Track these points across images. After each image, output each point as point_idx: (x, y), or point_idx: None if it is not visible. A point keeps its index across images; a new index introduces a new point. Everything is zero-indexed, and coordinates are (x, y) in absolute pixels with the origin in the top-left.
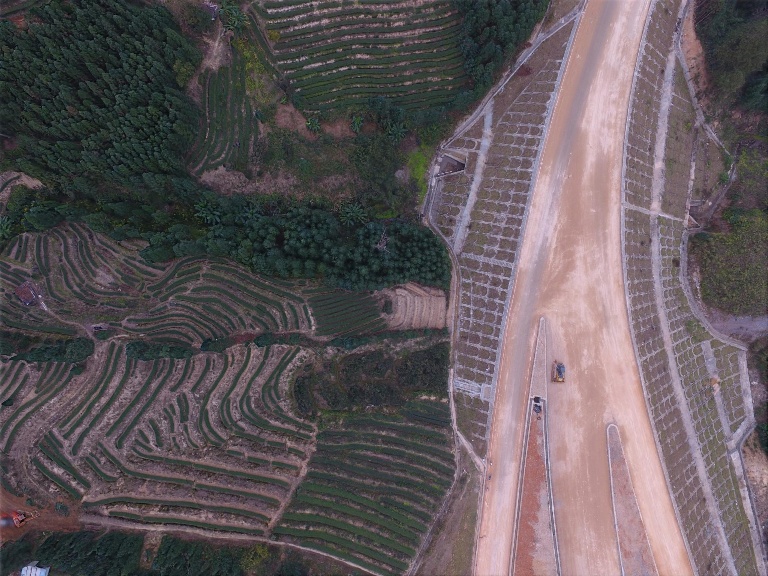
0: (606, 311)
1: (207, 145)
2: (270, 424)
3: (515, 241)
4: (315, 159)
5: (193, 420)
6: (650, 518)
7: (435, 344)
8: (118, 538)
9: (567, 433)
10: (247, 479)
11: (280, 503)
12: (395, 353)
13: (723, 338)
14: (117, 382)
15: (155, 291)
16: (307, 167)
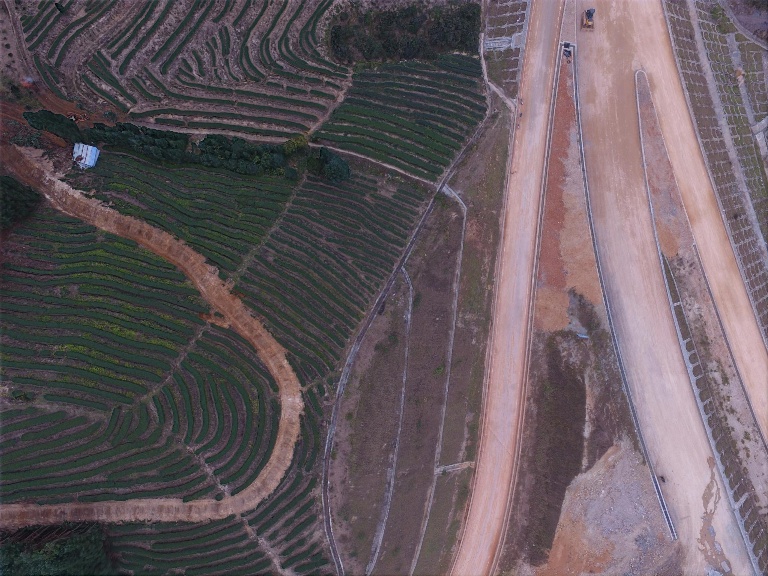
0: None
1: None
2: (307, 65)
3: None
4: None
5: (234, 54)
6: (678, 161)
7: (466, 6)
8: None
9: (596, 78)
10: (286, 103)
11: (318, 119)
12: (428, 12)
13: (747, 36)
14: (162, 7)
15: None
16: None
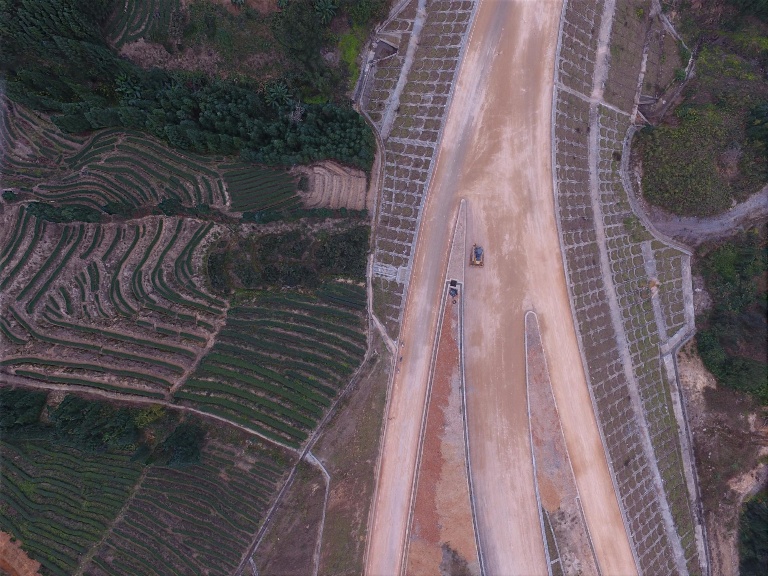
0: (531, 195)
1: (126, 15)
2: (182, 298)
3: (439, 120)
4: (238, 34)
5: (104, 290)
6: (566, 408)
7: (355, 227)
8: (20, 393)
9: (483, 318)
10: (154, 348)
11: (184, 371)
12: (313, 235)
13: (666, 240)
14: (26, 246)
15: (72, 163)
16: (225, 37)
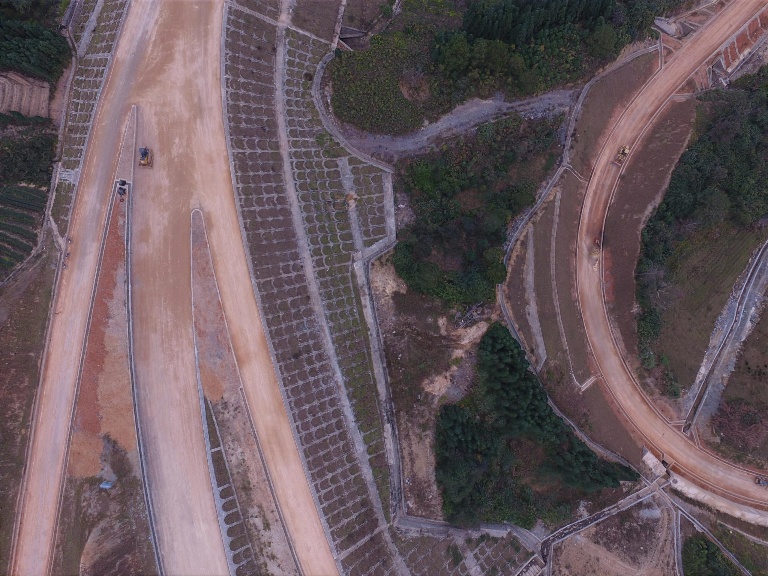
0: (201, 102)
1: None
2: None
3: (115, 33)
4: None
5: None
6: (231, 301)
7: None
8: None
9: (151, 216)
10: None
11: None
12: None
13: (365, 158)
14: None
15: None
16: None
